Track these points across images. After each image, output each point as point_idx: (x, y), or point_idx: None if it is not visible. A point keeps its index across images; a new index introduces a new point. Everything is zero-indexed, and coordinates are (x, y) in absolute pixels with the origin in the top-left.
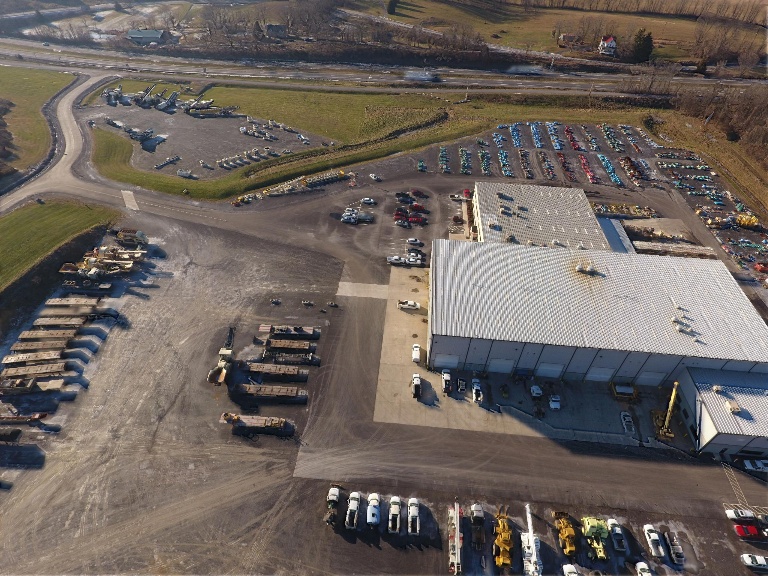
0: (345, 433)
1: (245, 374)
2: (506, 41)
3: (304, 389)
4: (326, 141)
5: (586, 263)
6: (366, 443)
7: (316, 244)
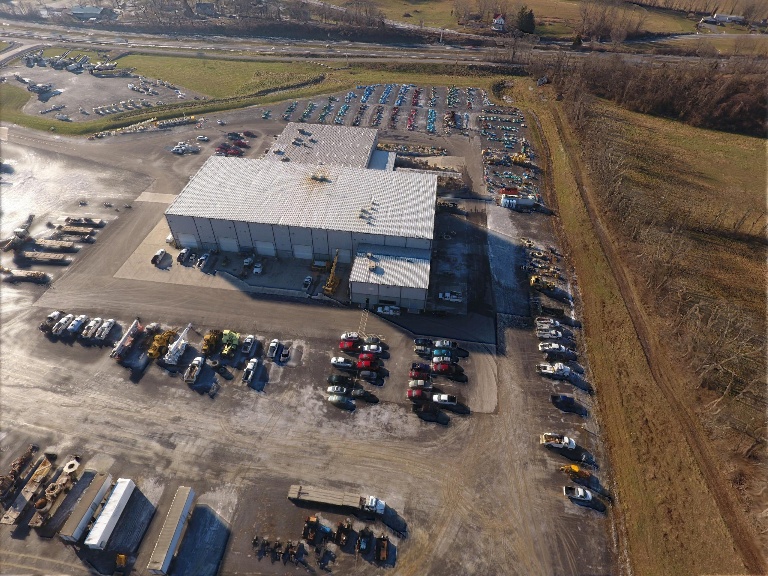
0: (87, 283)
1: (33, 247)
2: (414, 19)
3: (72, 257)
4: (199, 96)
5: (323, 174)
6: (99, 289)
7: (140, 167)
